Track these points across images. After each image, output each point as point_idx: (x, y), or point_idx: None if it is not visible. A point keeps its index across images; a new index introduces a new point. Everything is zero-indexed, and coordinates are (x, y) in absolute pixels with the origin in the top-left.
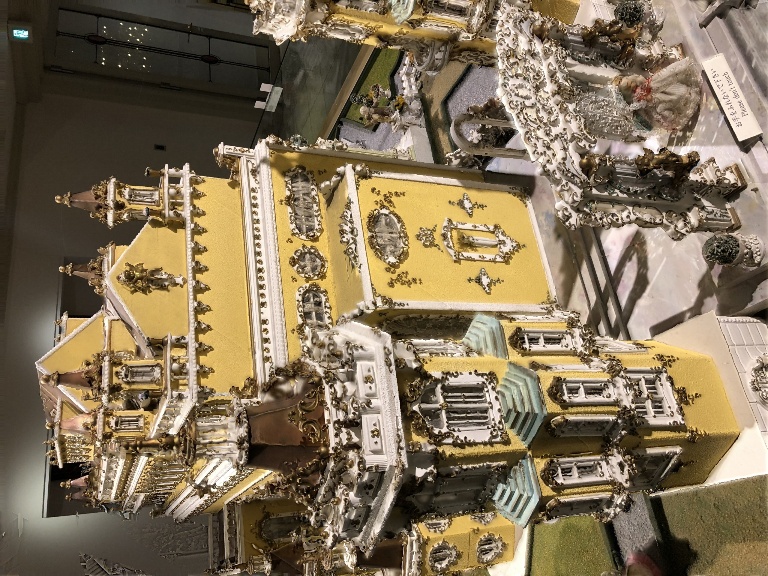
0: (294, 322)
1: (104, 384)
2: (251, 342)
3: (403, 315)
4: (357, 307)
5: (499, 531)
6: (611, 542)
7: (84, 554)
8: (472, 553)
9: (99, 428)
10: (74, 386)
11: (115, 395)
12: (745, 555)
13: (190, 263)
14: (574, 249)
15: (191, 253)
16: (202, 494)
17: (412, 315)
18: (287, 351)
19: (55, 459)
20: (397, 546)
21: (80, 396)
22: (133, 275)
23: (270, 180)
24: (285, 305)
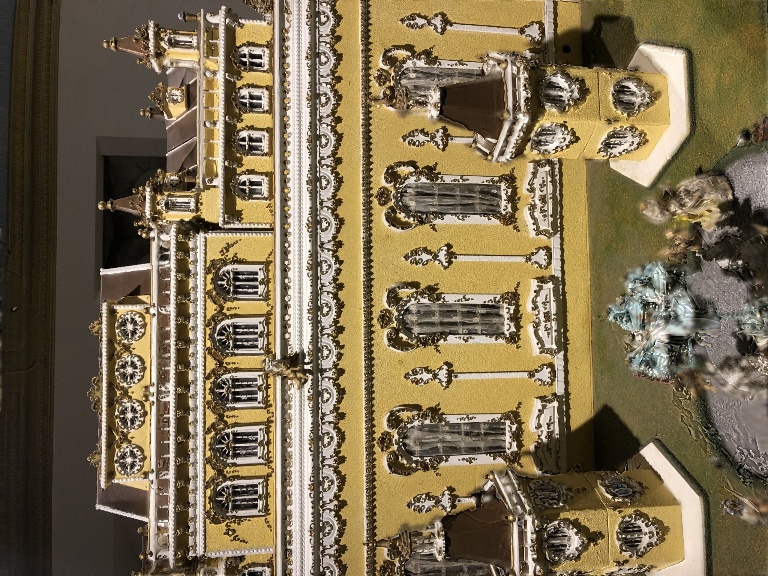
0: None
1: None
2: None
3: None
4: None
5: None
6: None
7: None
8: None
9: None
10: (128, 39)
11: None
12: None
13: None
14: None
15: None
16: None
17: None
18: None
19: (99, 435)
20: None
21: None
22: None
23: None
24: None
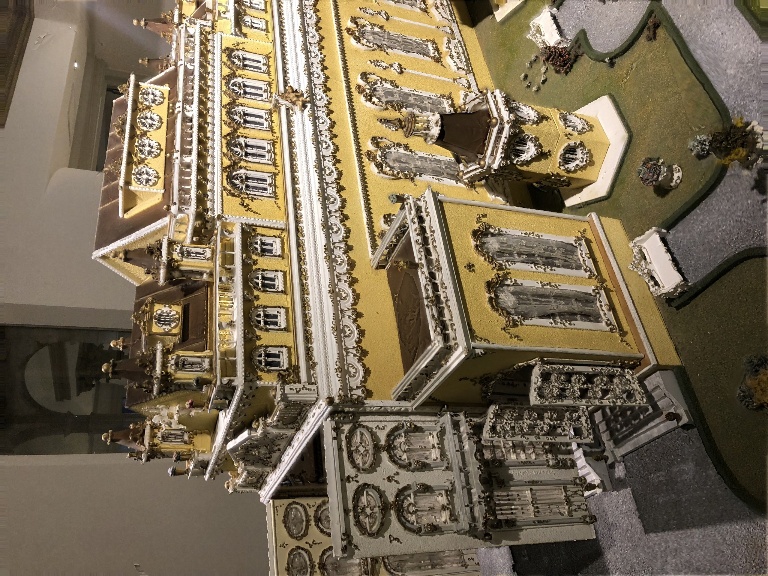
0: None
1: None
2: None
3: None
4: None
5: None
6: None
7: (135, 565)
8: None
9: None
10: None
11: None
12: None
13: None
14: None
15: None
16: None
17: None
18: None
19: (120, 153)
20: None
21: None
22: None
23: None
24: None
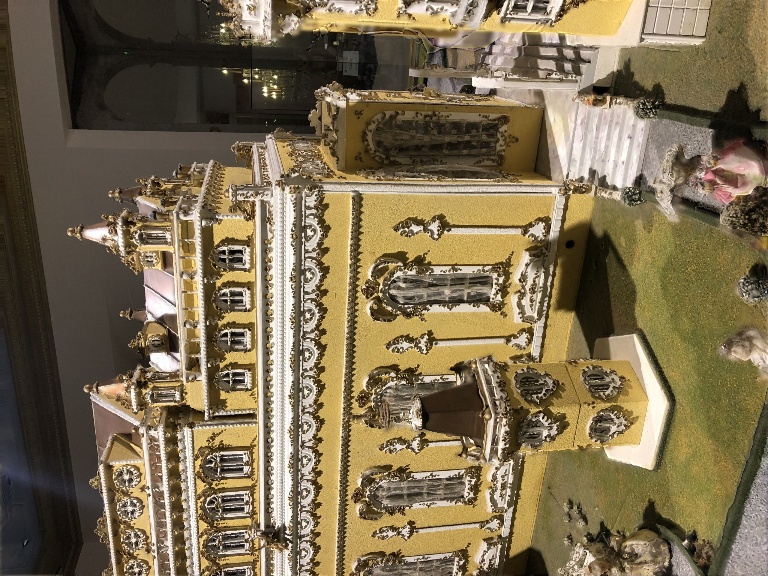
0: (291, 167)
1: (119, 217)
2: (252, 180)
3: (379, 114)
4: (331, 104)
5: (608, 366)
6: (690, 206)
7: None
8: (580, 389)
9: (134, 377)
10: (94, 230)
11: (130, 234)
12: (764, 12)
13: (206, 178)
14: (530, 67)
15: (208, 177)
16: (270, 540)
17: (388, 113)
18: (283, 171)
19: (109, 557)
20: (471, 385)
21: (129, 414)
22: (158, 188)
23: (274, 142)
24: (283, 164)
